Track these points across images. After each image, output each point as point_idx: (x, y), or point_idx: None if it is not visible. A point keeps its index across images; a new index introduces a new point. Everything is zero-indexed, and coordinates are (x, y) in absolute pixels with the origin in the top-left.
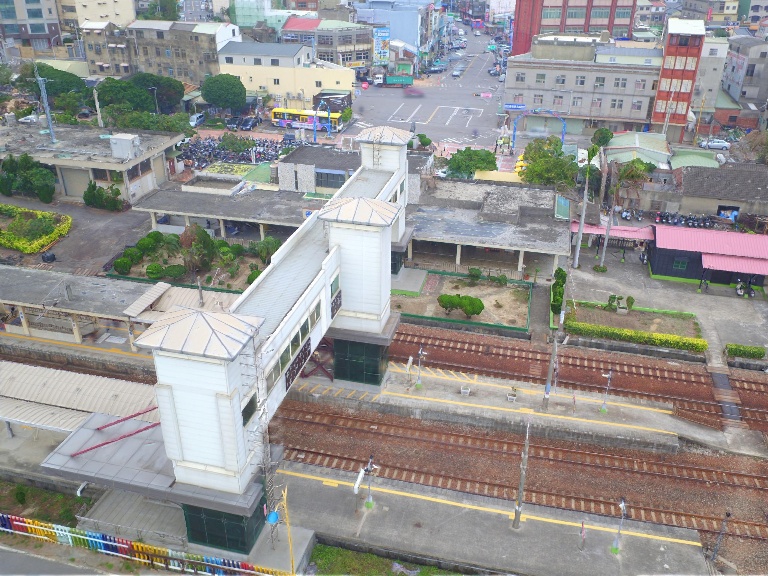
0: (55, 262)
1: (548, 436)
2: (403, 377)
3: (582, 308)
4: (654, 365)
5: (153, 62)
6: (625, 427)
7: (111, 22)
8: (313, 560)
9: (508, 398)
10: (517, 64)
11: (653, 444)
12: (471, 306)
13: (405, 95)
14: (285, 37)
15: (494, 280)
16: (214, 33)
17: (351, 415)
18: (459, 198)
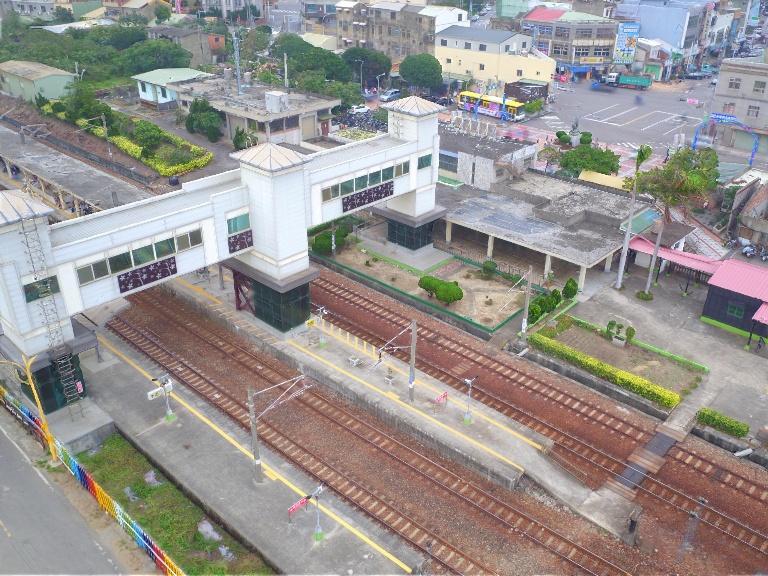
0: (176, 186)
1: (398, 427)
2: (318, 334)
3: (578, 328)
4: (597, 404)
5: (385, 40)
6: (472, 443)
7: (361, 2)
8: (104, 444)
9: (385, 379)
10: (733, 67)
11: (487, 470)
12: (444, 292)
13: (630, 96)
14: (525, 27)
15: (505, 278)
16: (435, 16)
17: (254, 353)
18: (534, 192)
